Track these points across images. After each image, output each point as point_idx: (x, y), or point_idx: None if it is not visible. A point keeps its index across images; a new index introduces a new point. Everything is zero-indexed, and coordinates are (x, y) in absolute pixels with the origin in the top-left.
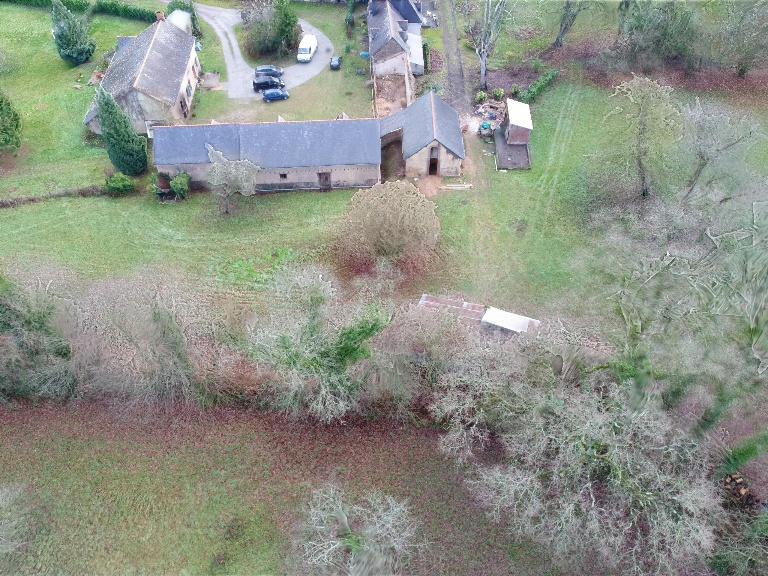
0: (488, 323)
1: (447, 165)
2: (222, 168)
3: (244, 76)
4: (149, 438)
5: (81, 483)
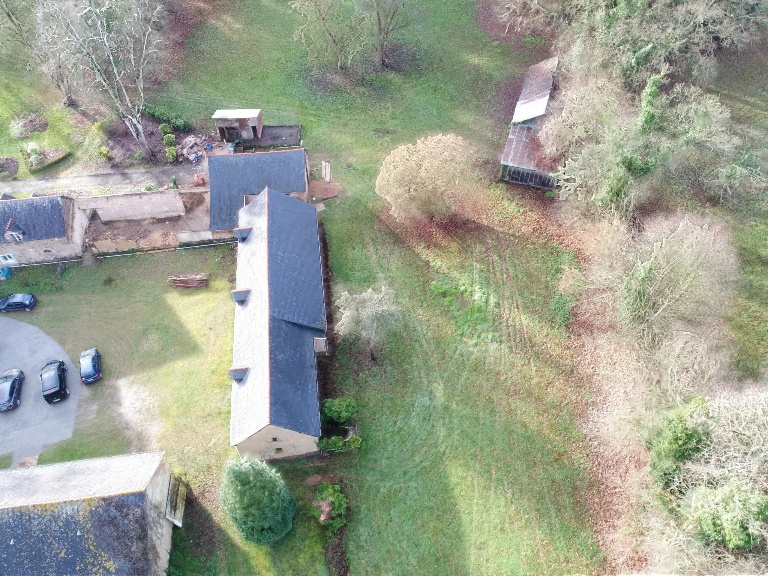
0: (546, 110)
1: (307, 167)
2: (372, 308)
3: (0, 432)
4: (699, 332)
5: (763, 370)
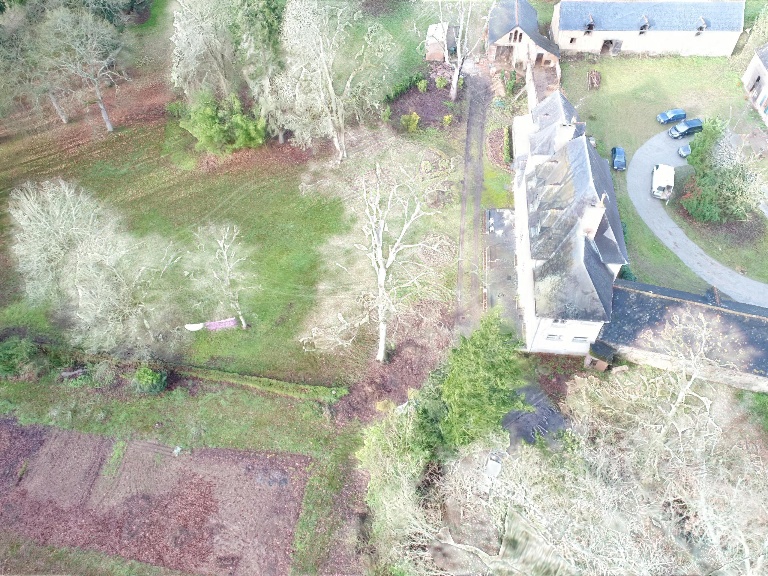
0: None
1: None
2: None
3: None
4: None
5: None
